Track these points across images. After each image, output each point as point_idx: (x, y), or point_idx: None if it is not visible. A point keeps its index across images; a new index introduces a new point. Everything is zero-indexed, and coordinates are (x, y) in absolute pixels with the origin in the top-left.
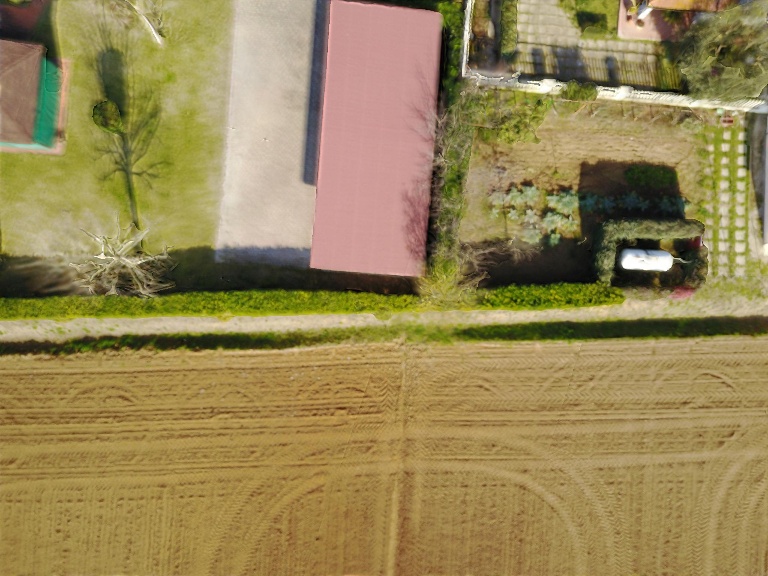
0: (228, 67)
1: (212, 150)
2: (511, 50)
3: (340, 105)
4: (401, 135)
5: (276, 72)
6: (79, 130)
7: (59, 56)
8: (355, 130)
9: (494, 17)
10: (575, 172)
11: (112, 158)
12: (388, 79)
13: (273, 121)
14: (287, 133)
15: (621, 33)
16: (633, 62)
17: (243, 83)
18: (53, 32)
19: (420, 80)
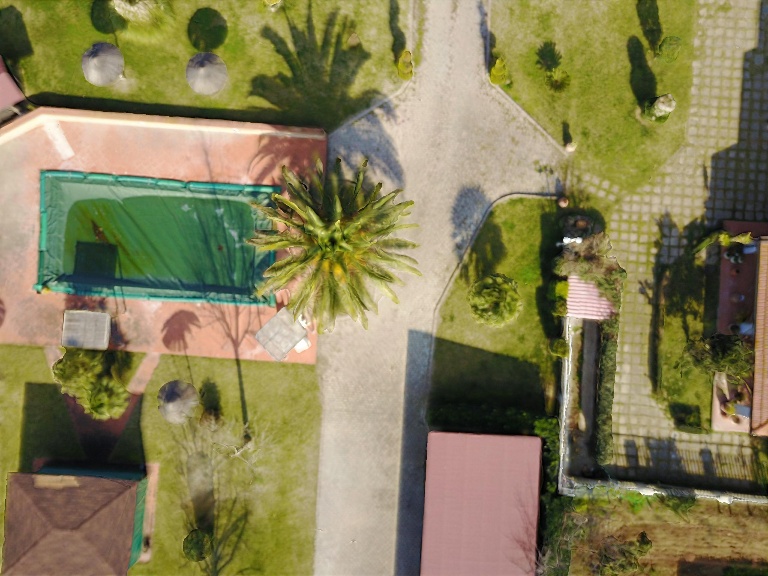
0: (314, 466)
1: (299, 553)
2: (608, 463)
3: (439, 542)
4: (501, 568)
5: (363, 470)
6: (163, 536)
7: (143, 460)
8: (454, 567)
9: (584, 409)
10: (672, 569)
11: (197, 565)
12: (486, 509)
13: (361, 522)
14: (375, 533)
15: (715, 426)
16: (728, 454)
17: (330, 482)
18: (137, 436)
19: (519, 509)
